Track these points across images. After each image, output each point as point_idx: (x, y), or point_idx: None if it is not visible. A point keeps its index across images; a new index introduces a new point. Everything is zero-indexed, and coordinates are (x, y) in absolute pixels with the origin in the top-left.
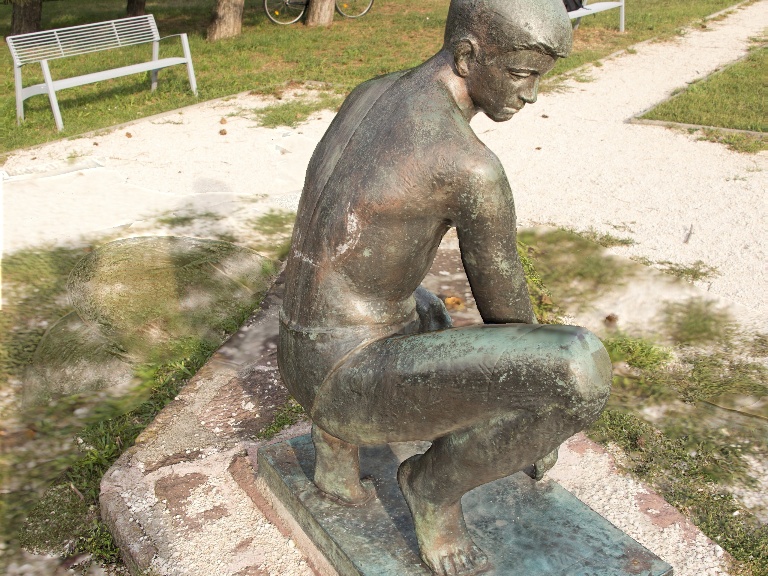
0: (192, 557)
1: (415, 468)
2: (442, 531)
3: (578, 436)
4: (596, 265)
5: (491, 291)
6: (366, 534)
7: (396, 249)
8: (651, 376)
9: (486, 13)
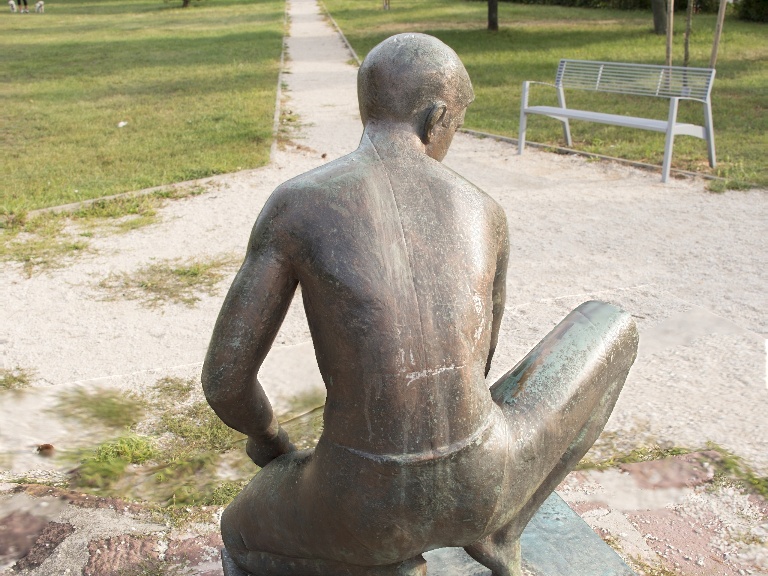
0: None
1: None
2: None
3: None
4: None
5: None
6: None
7: None
8: (168, 457)
9: (455, 78)
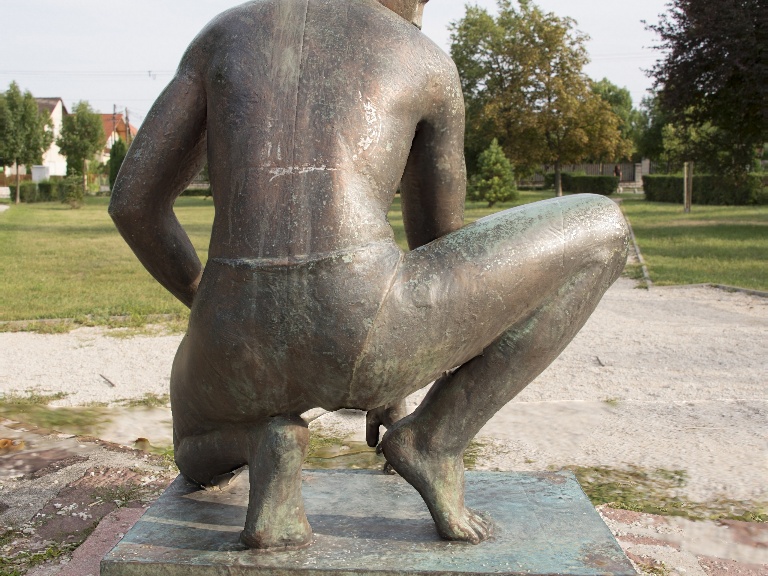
0: None
1: (423, 424)
2: (460, 490)
3: None
4: (58, 415)
5: (456, 199)
6: (365, 552)
7: (406, 145)
8: None
9: None
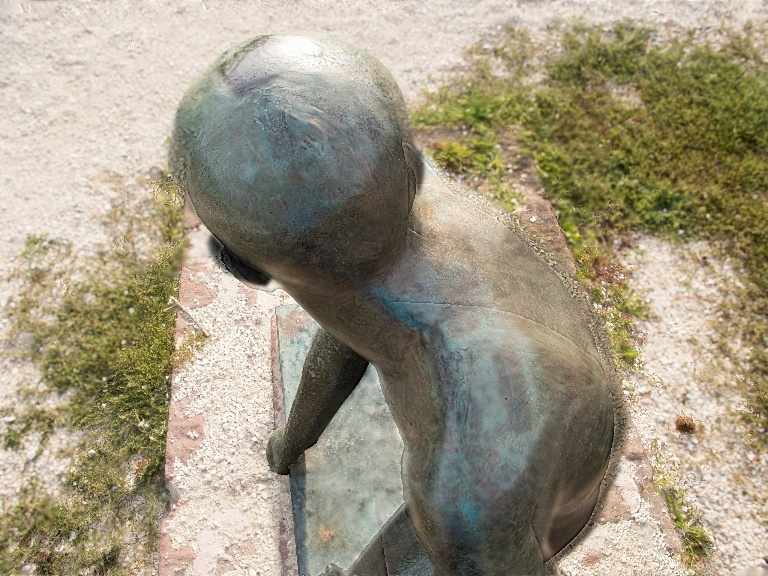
0: (644, 567)
1: None
2: None
3: (169, 575)
4: None
5: None
6: None
7: None
8: None
9: None
